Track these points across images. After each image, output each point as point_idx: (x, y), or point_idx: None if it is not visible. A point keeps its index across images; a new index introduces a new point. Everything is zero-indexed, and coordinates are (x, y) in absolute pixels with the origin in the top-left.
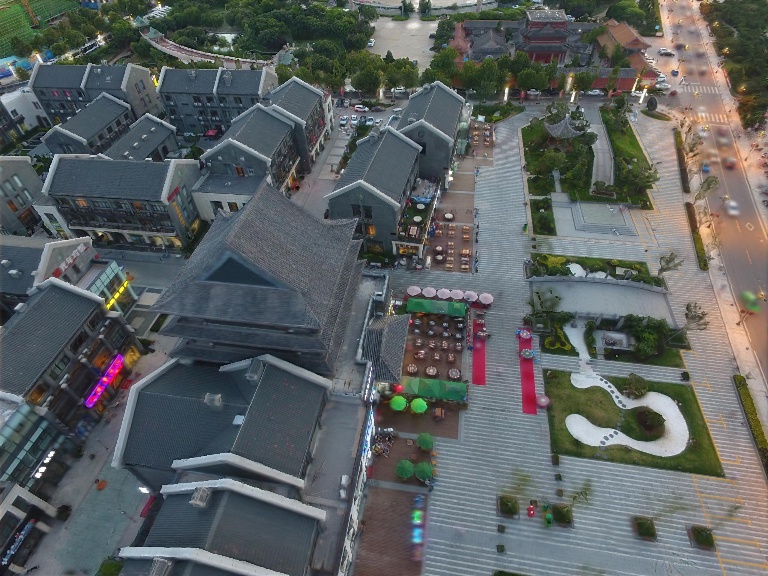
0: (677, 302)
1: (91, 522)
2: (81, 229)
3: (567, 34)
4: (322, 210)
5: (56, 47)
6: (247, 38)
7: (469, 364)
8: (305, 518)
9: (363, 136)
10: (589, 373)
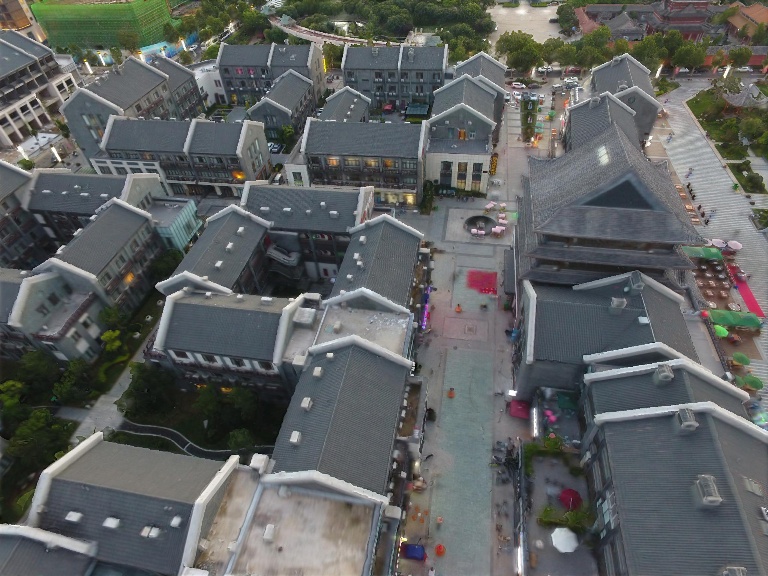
0: None
1: (459, 422)
2: (323, 187)
3: (709, 14)
4: None
5: (203, 33)
6: (373, 24)
7: (741, 300)
8: (733, 398)
9: (533, 109)
10: None
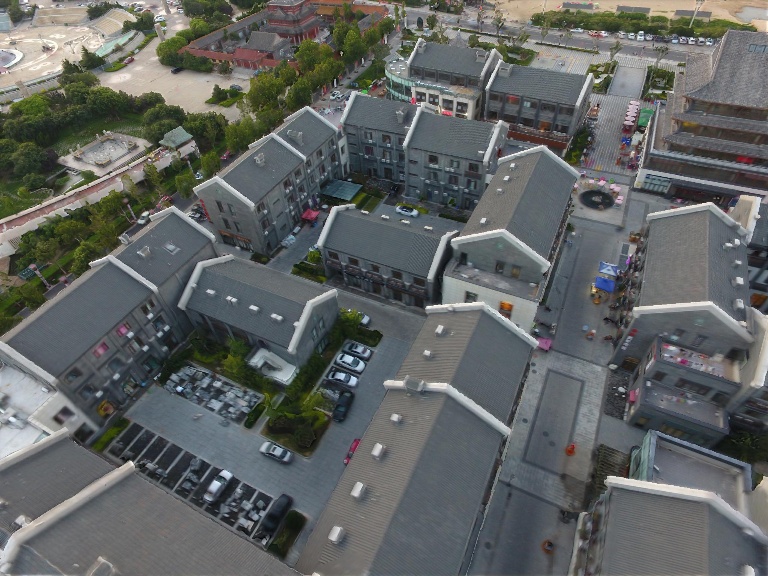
0: None
1: None
2: None
3: (317, 7)
4: None
5: None
6: None
7: None
8: None
9: None
10: None
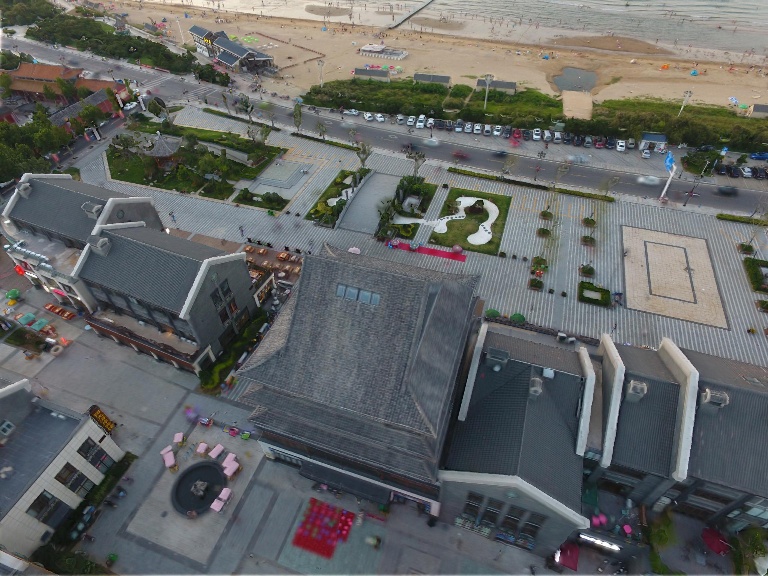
0: (384, 170)
1: None
2: None
3: (0, 91)
4: (119, 376)
5: None
6: None
7: None
8: None
9: None
10: (435, 223)
